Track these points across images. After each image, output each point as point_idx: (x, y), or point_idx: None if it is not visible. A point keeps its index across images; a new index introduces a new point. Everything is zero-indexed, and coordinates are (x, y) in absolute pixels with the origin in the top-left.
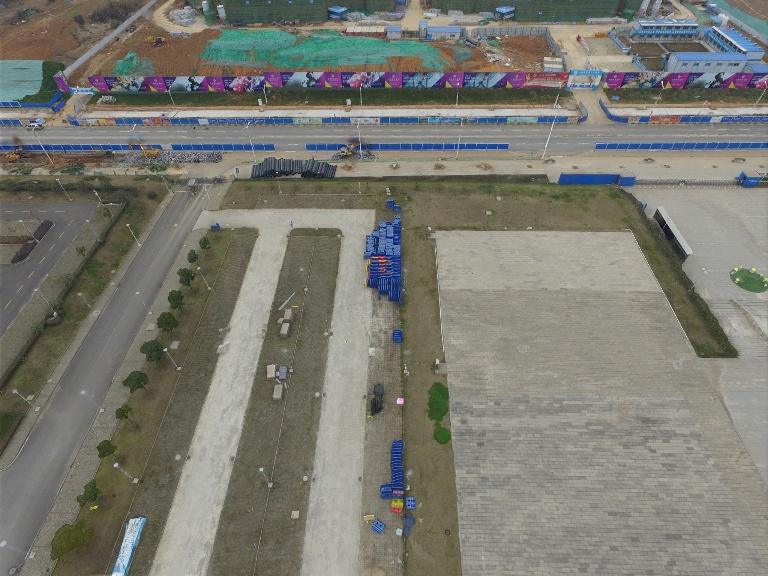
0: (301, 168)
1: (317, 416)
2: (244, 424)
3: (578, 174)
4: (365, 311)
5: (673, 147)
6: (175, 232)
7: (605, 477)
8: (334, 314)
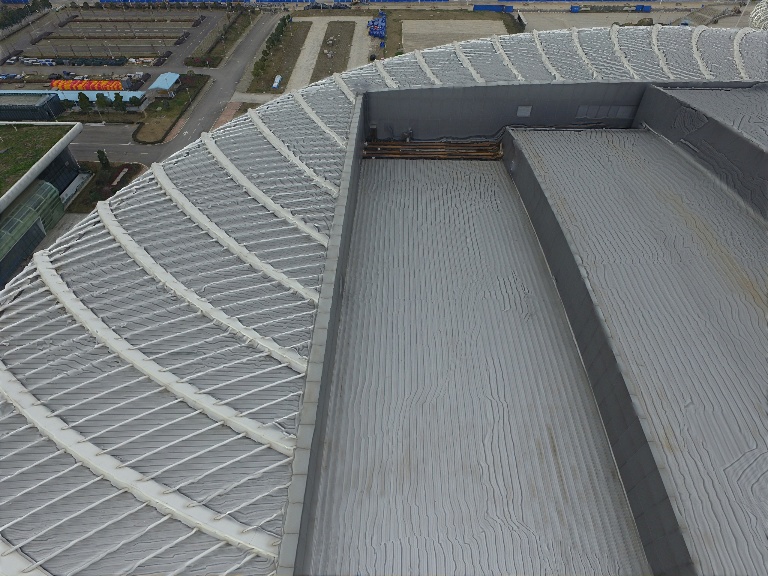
0: (331, 7)
1: (347, 61)
2: (316, 62)
3: (483, 5)
4: (368, 41)
5: (541, 0)
6: (269, 23)
7: None
8: (353, 41)
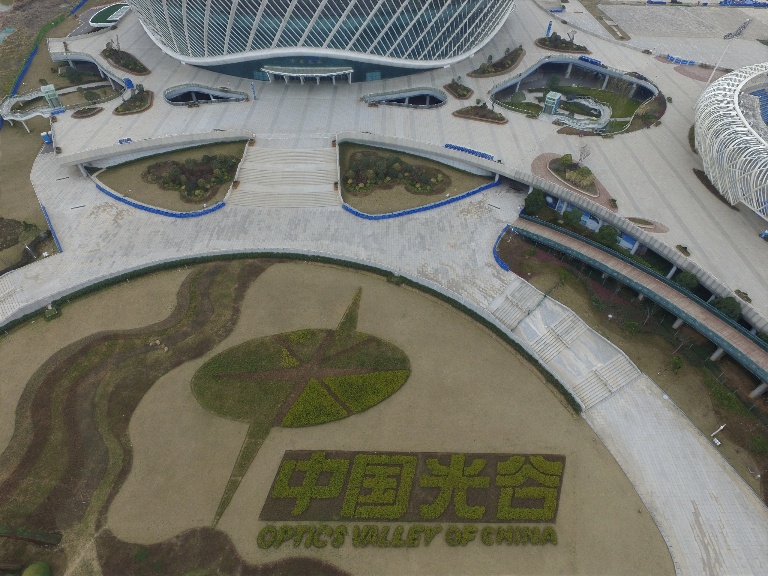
0: None
1: None
2: None
3: None
4: (710, 2)
5: None
6: None
7: None
8: None
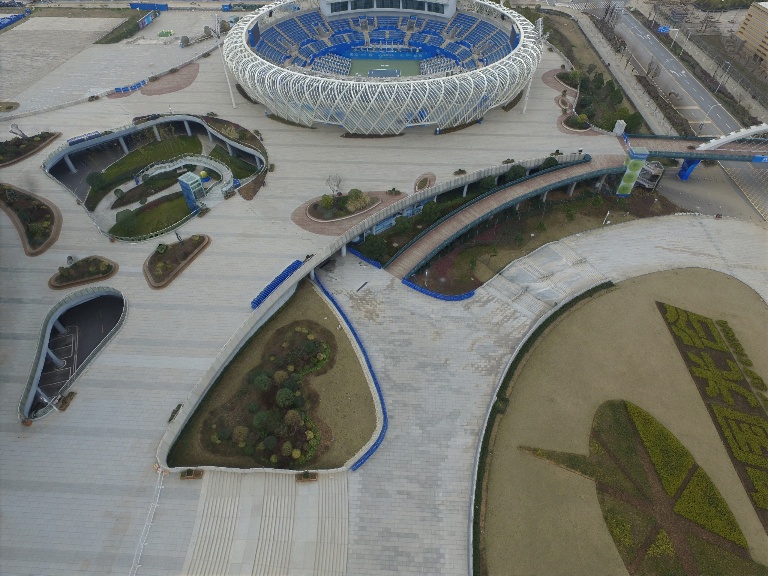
0: None
1: None
2: None
3: (137, 3)
4: None
5: None
6: None
7: (5, 62)
8: None
